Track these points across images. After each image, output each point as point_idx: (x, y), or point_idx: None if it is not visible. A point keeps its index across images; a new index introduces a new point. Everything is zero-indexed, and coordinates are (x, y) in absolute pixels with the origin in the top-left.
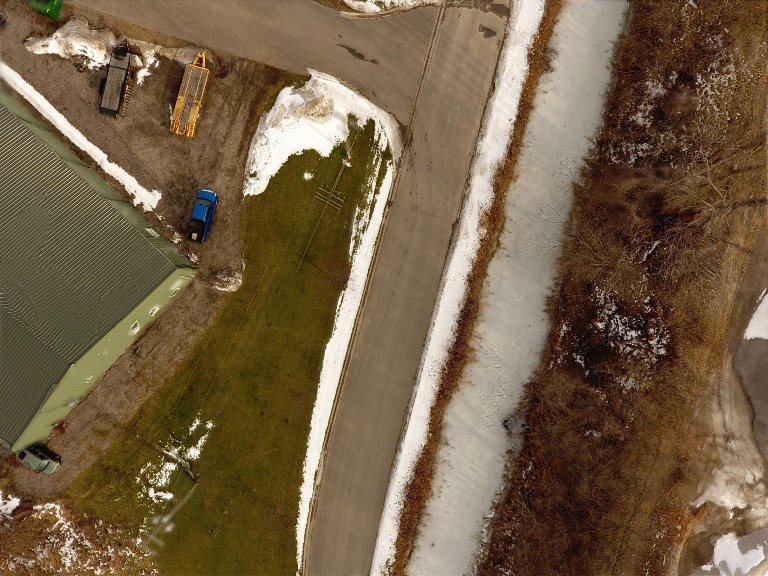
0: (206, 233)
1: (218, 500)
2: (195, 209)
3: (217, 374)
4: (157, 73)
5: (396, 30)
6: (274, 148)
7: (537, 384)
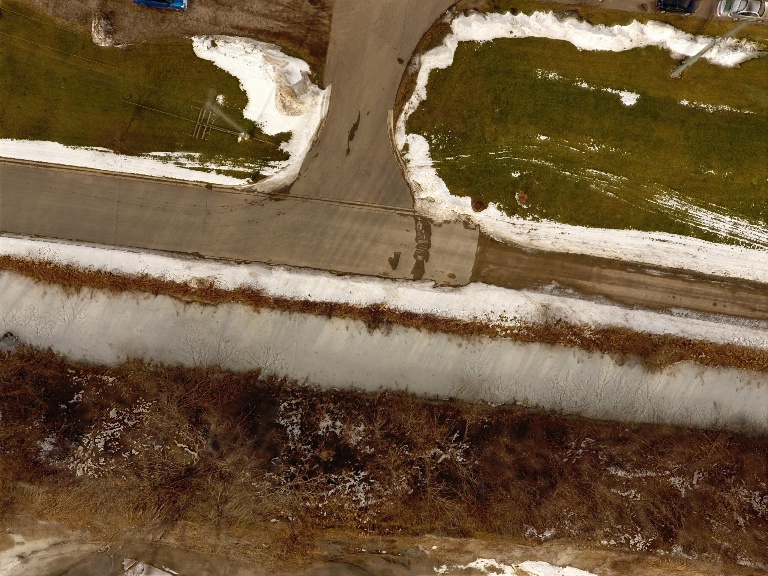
0: (143, 2)
1: None
2: None
3: (5, 33)
4: None
5: (383, 169)
6: (242, 61)
7: (50, 359)
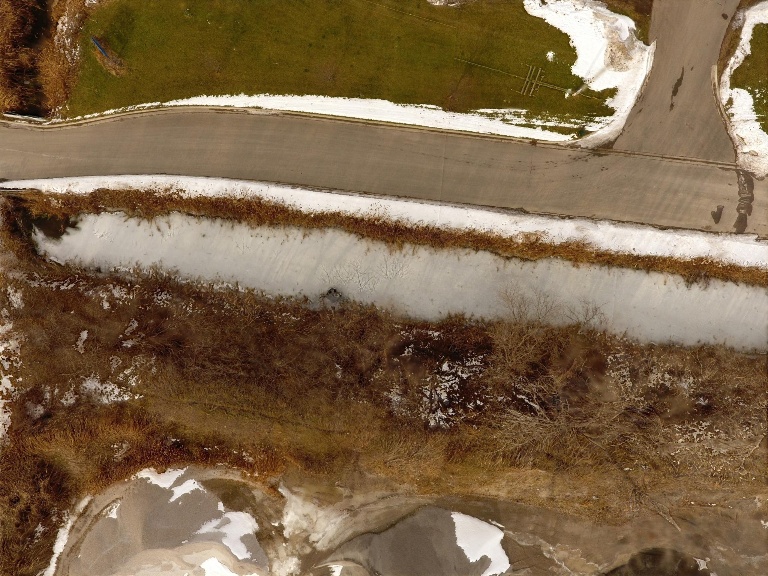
0: None
1: (220, 13)
2: None
3: None
4: None
5: (707, 123)
6: (573, 18)
7: (377, 314)
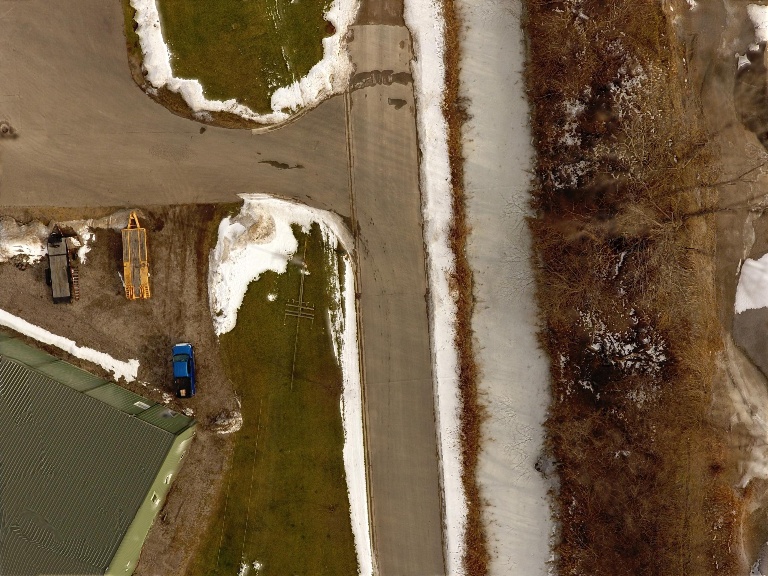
0: (193, 385)
1: None
2: (175, 367)
3: (248, 515)
4: (96, 246)
5: (310, 130)
6: (231, 282)
7: (554, 421)
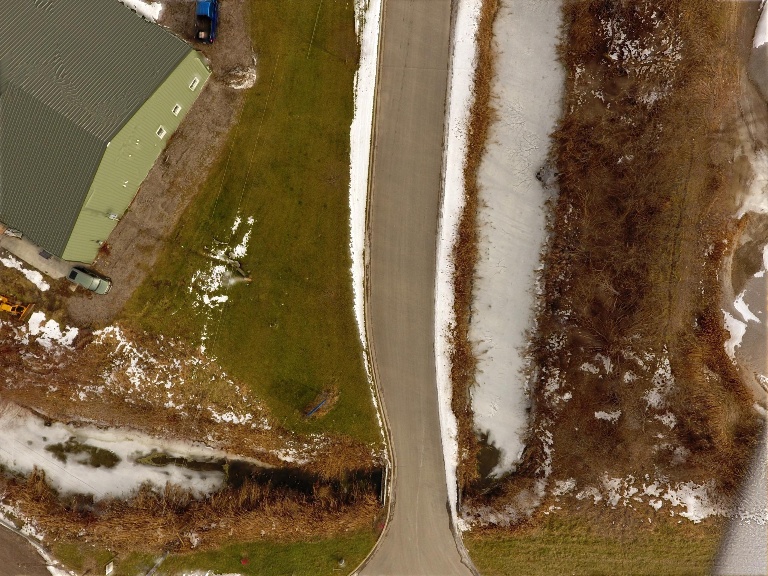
0: (212, 32)
1: (273, 293)
2: (197, 8)
3: (249, 170)
4: None
5: None
6: None
7: (562, 130)
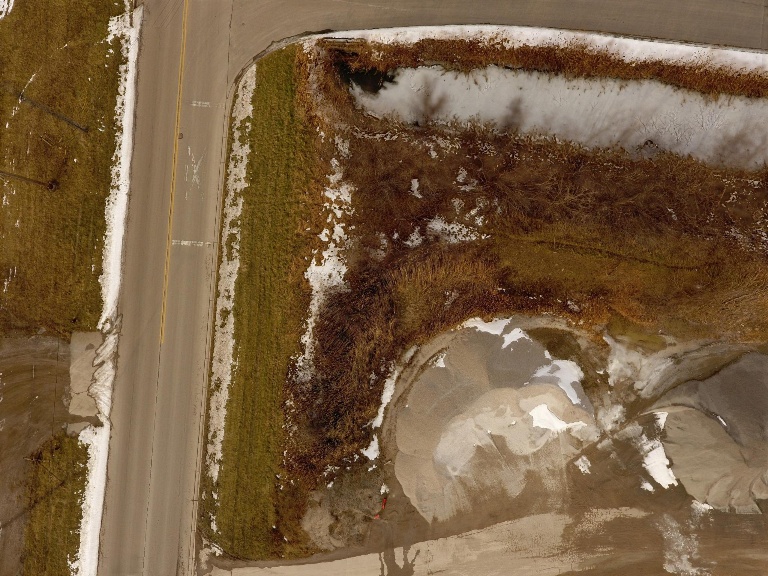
0: None
1: None
2: None
3: None
4: None
5: None
6: None
7: None
